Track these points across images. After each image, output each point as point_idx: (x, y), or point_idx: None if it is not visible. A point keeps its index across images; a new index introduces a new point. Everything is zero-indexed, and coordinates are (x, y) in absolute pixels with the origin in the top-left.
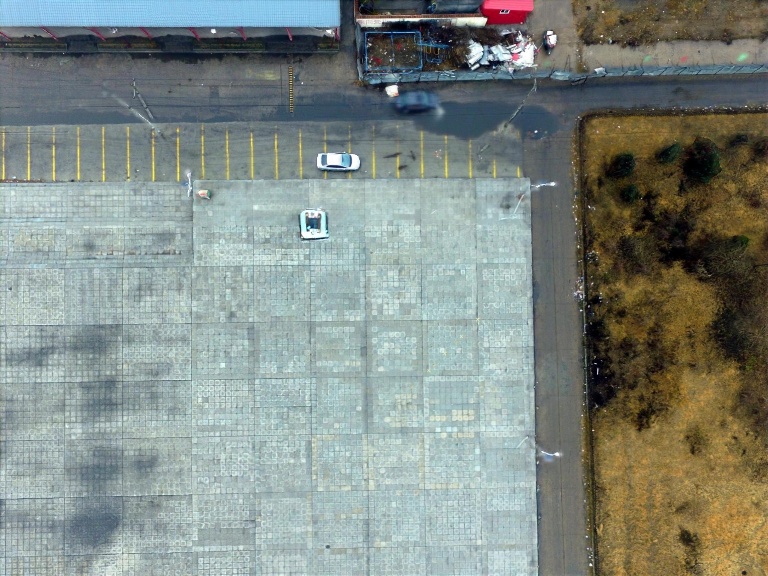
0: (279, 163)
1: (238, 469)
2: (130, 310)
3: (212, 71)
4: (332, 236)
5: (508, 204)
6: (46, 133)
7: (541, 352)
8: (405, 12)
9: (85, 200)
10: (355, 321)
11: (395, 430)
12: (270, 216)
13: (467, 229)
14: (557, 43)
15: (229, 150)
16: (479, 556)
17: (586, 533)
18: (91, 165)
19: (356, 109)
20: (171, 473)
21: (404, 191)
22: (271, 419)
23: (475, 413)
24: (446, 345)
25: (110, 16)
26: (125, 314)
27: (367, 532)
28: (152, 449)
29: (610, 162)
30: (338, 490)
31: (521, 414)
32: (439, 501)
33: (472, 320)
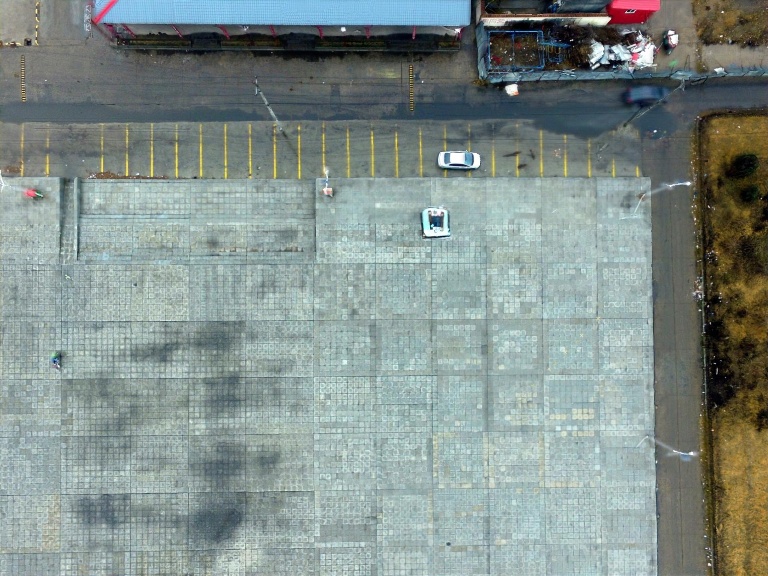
0: (399, 161)
1: (360, 466)
2: (253, 307)
3: (333, 69)
4: (453, 234)
5: (629, 203)
6: (169, 130)
7: (660, 352)
8: (525, 11)
9: (208, 197)
10: (476, 319)
11: (515, 428)
12: (392, 214)
13: (588, 228)
14: (677, 43)
15: (350, 148)
16: (599, 555)
17: (705, 533)
18: (213, 162)
19: (476, 108)
20: (293, 469)
21: (525, 190)
22: (392, 416)
23: (595, 412)
24: (566, 344)
25: (243, 14)
26: (248, 311)
27: (487, 530)
28: (275, 445)
29: (730, 162)
30: (459, 488)
31: (641, 413)
32: (559, 499)
33: (592, 319)
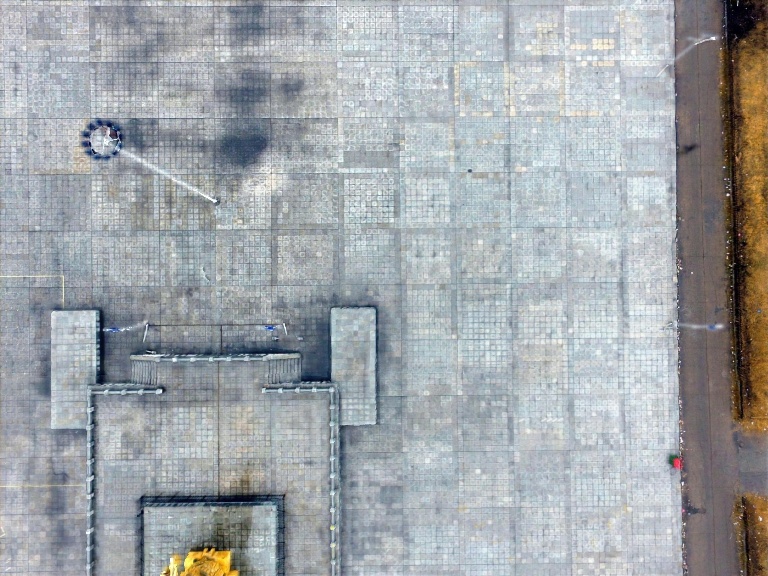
0: None
1: (382, 94)
2: None
3: None
4: None
5: None
6: None
7: None
8: None
9: None
10: None
11: (536, 58)
12: None
13: None
14: None
15: None
16: (618, 182)
17: (724, 164)
18: None
19: None
20: (317, 97)
21: None
22: (414, 45)
23: (615, 42)
24: None
25: None
26: None
27: (508, 157)
28: (299, 73)
29: None
30: (480, 116)
31: (661, 44)
32: (579, 128)
33: None
